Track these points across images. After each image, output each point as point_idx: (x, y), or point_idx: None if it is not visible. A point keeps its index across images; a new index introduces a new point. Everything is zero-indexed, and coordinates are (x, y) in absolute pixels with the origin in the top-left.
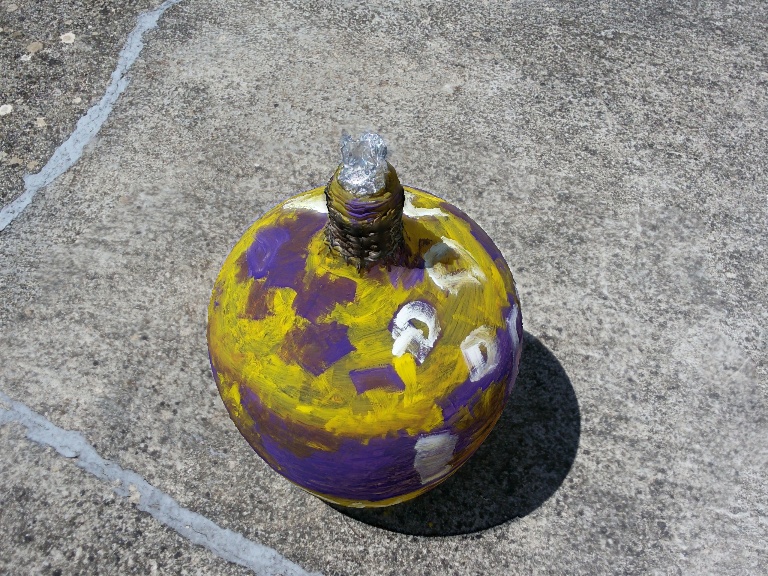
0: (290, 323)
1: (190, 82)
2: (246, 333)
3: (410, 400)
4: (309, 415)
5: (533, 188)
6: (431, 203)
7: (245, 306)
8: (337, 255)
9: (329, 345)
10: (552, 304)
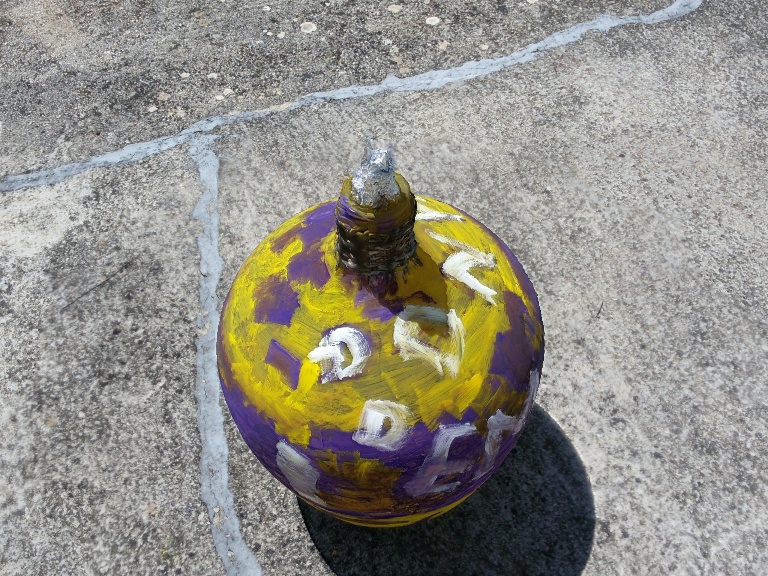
0: (279, 269)
1: (579, 90)
2: (260, 254)
3: (291, 402)
4: (230, 346)
5: (766, 404)
6: (496, 283)
7: (280, 236)
8: (335, 243)
9: (280, 307)
10: (648, 509)
